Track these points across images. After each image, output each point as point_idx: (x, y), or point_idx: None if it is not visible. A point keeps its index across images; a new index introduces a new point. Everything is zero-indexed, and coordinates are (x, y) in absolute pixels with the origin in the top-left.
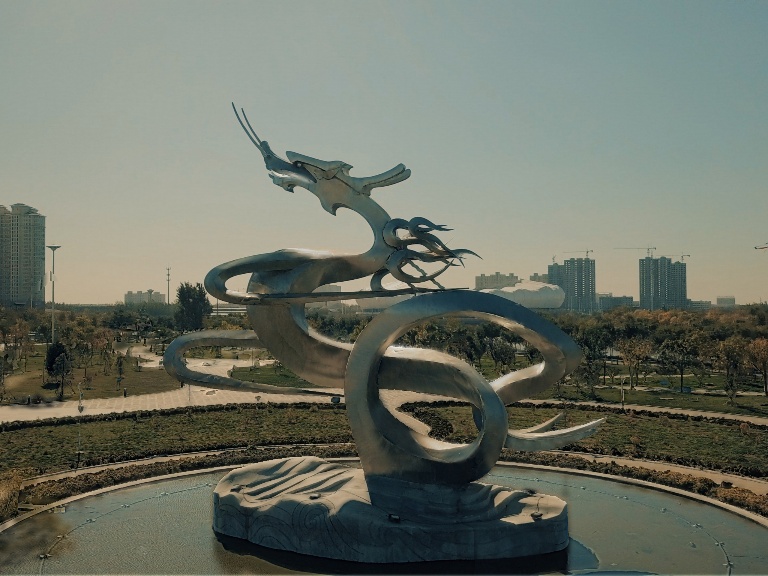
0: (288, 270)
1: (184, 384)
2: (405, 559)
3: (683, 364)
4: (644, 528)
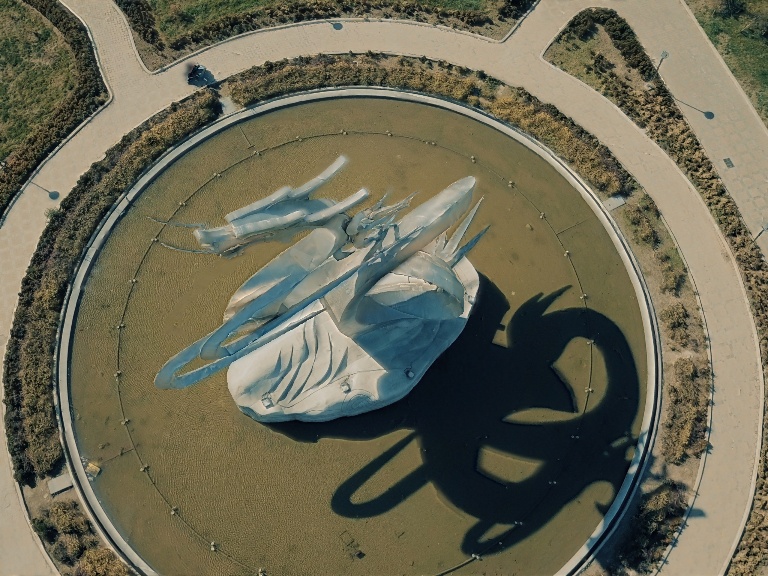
0: None
1: None
2: None
3: None
4: (485, 207)
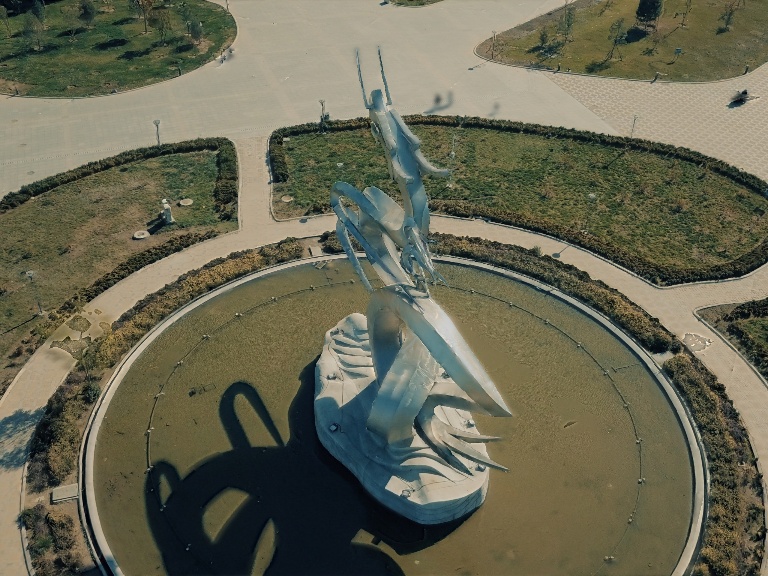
0: None
1: (758, 66)
2: None
3: None
4: (538, 557)
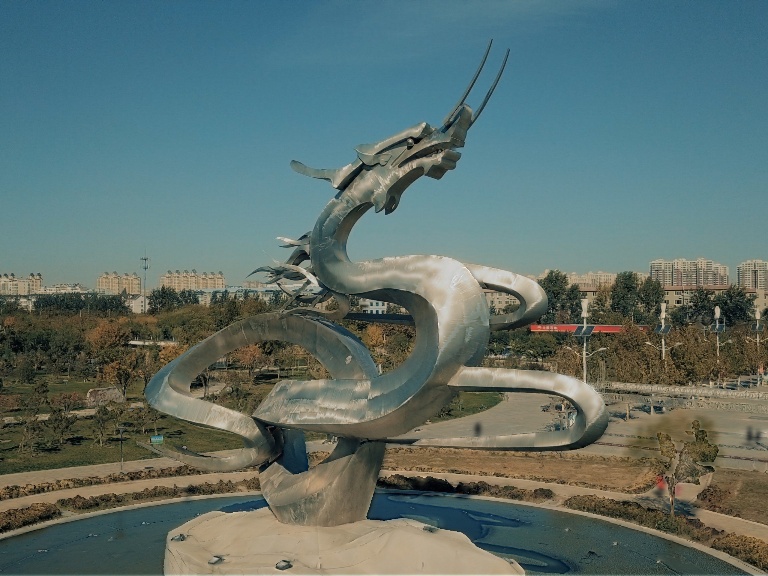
0: None
1: None
2: None
3: None
4: (85, 560)
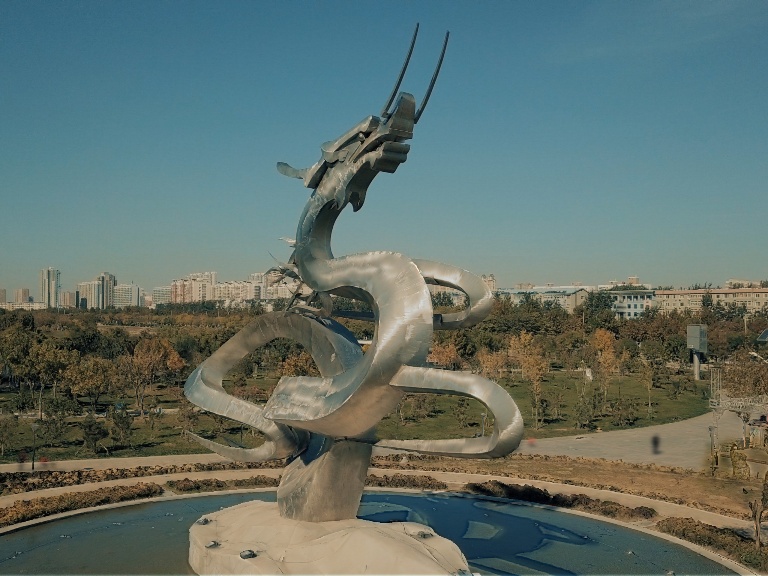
0: None
1: None
2: None
3: None
4: None
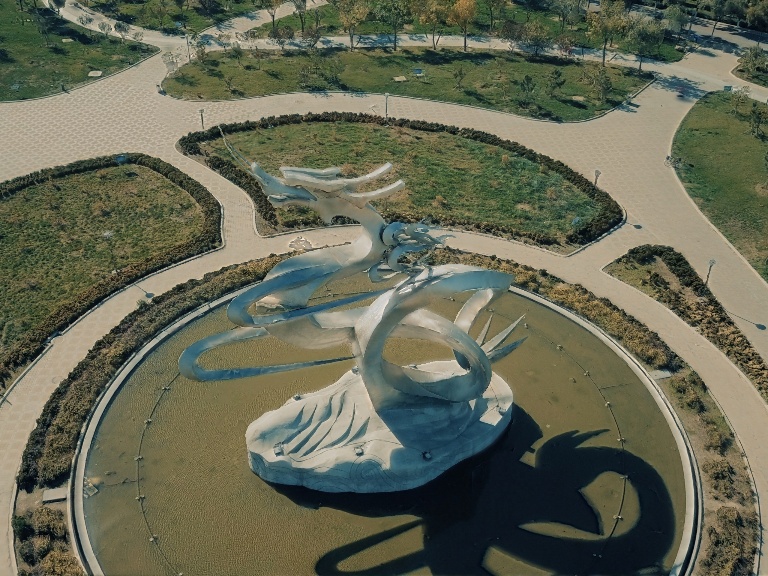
0: (302, 285)
1: None
2: (435, 476)
3: (397, 23)
4: (531, 360)
